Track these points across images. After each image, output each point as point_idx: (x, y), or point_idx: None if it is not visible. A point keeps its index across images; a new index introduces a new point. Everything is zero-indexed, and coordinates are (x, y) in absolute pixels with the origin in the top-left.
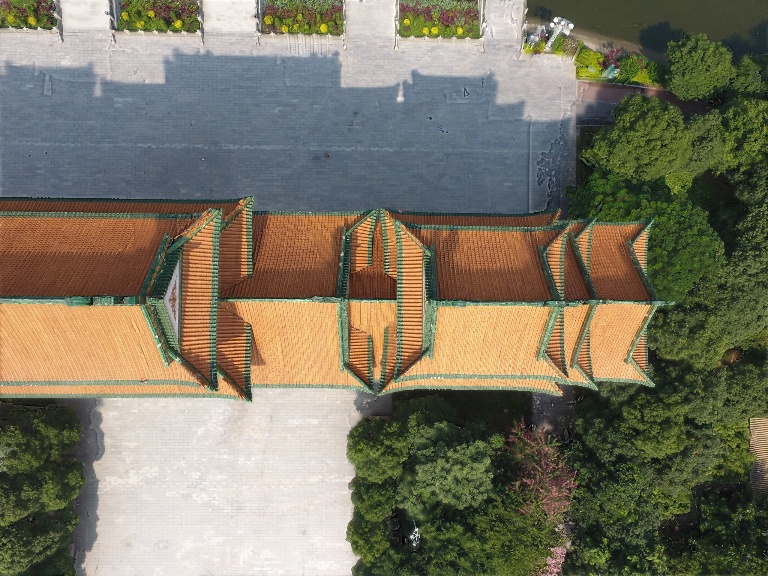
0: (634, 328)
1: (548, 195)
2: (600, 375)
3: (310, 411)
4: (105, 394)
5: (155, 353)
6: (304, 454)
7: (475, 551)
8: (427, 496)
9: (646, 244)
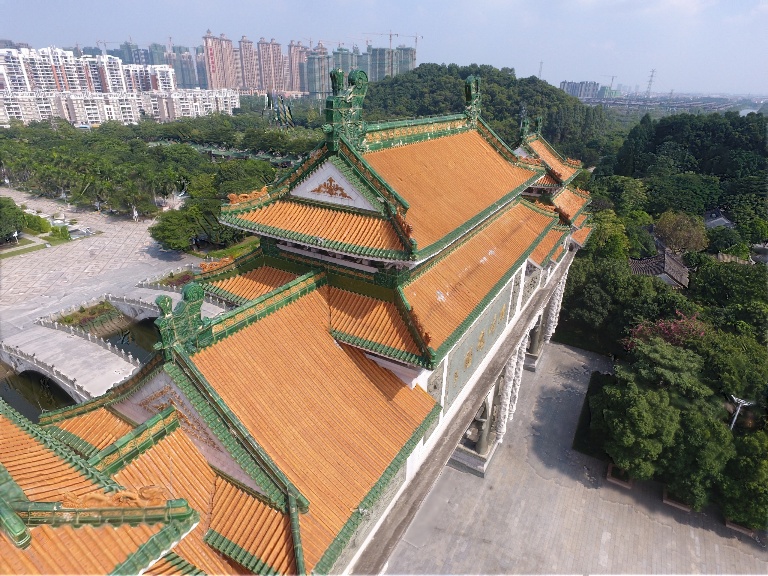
0: None
1: None
2: None
3: (590, 534)
4: (522, 256)
5: None
6: (655, 570)
7: (749, 364)
8: (692, 382)
9: None
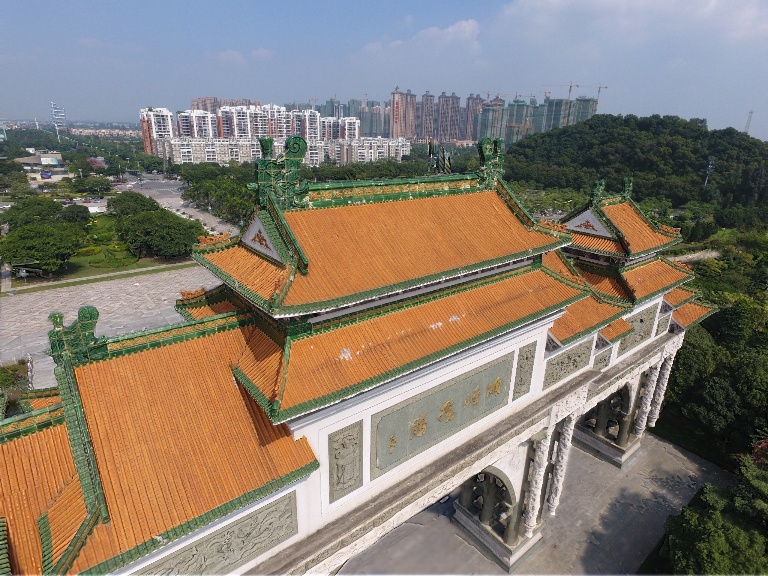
0: None
1: None
2: (696, 317)
3: None
4: (500, 328)
5: (518, 228)
6: None
7: None
8: None
9: None
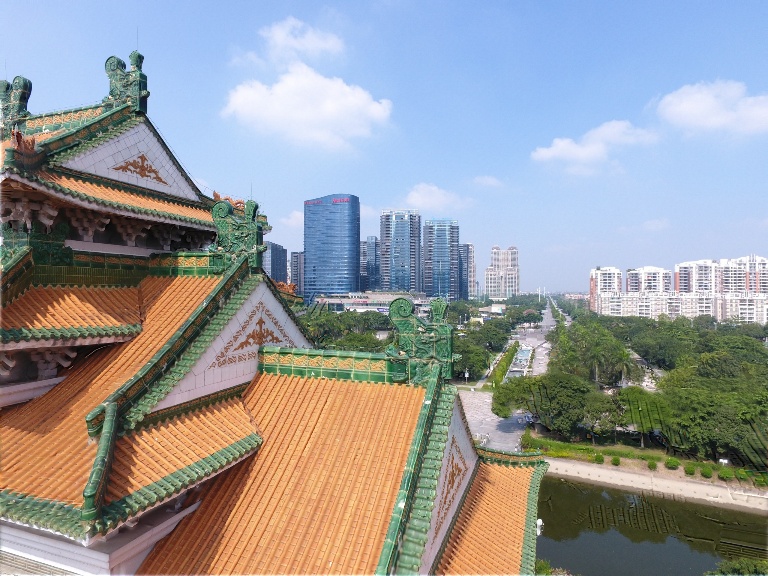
0: (397, 476)
1: None
2: None
3: None
4: None
5: None
6: None
7: None
8: None
9: (533, 491)
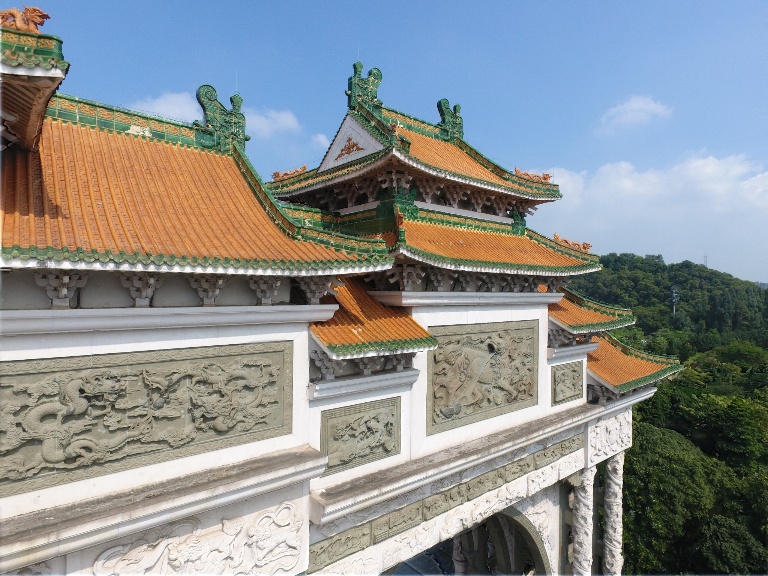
0: None
1: (427, 555)
2: (638, 375)
3: None
4: None
5: None
6: None
7: None
8: None
9: None
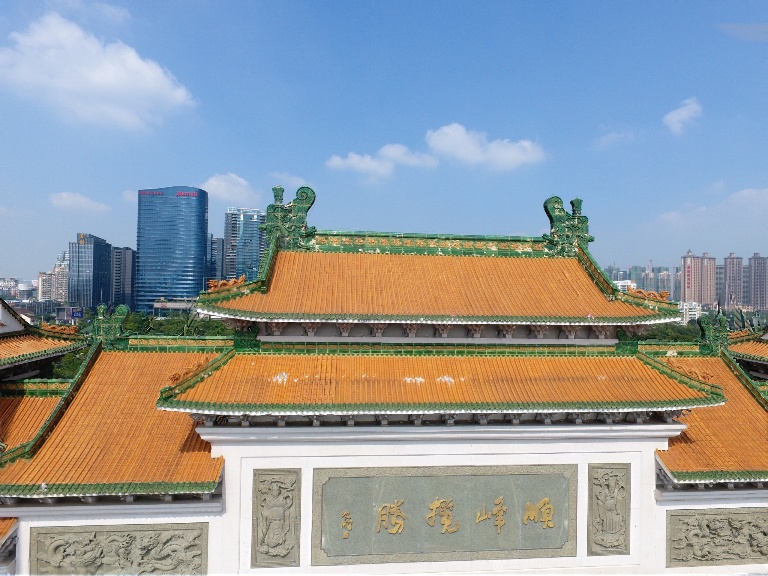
0: None
1: None
2: None
3: None
4: (511, 403)
5: (592, 296)
6: None
7: None
8: None
9: None
